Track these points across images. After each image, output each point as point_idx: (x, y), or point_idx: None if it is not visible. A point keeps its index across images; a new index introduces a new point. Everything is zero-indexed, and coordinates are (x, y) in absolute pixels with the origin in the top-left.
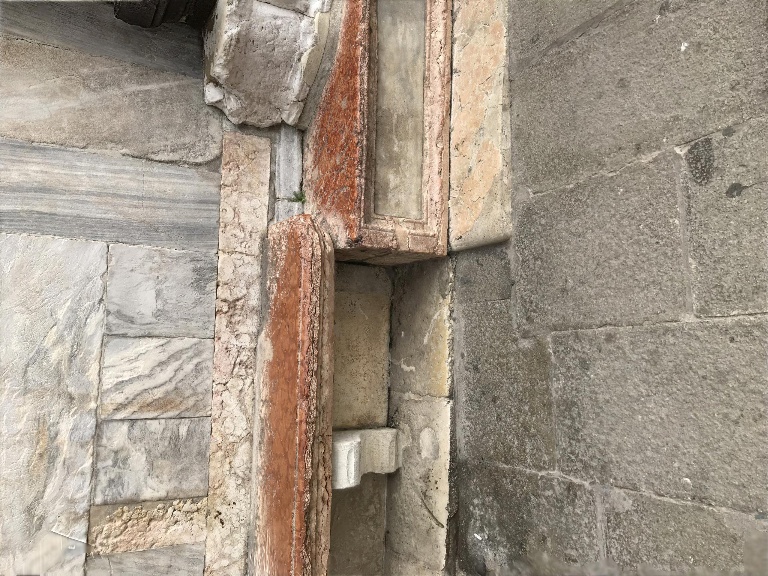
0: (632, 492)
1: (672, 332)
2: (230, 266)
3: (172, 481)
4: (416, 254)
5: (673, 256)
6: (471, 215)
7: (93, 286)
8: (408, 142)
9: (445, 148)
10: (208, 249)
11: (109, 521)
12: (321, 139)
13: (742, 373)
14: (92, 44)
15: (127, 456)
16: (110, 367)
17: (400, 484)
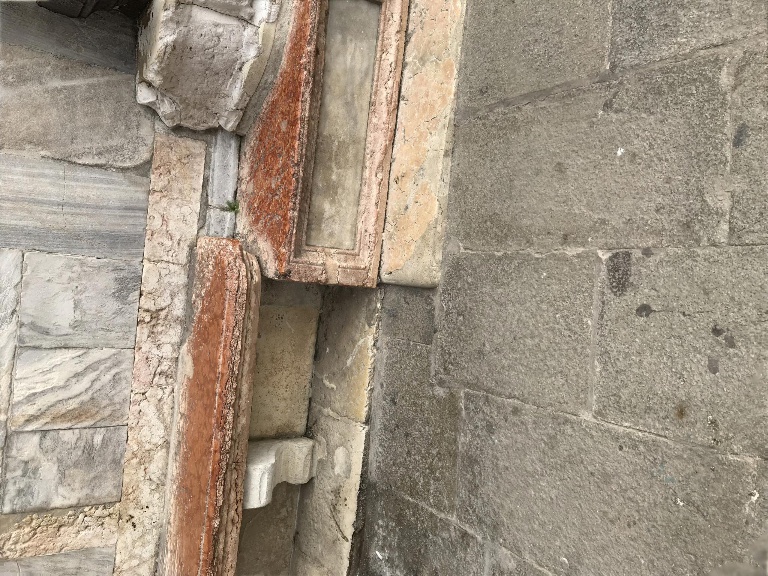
0: (517, 557)
1: (571, 424)
2: (155, 275)
3: (84, 489)
4: (345, 286)
5: (582, 354)
6: (403, 254)
7: (6, 296)
8: (347, 170)
9: (384, 179)
10: (132, 257)
11: (17, 528)
12: (258, 153)
13: (625, 481)
14: (10, 31)
15: (38, 466)
16: (22, 379)
17: (312, 492)
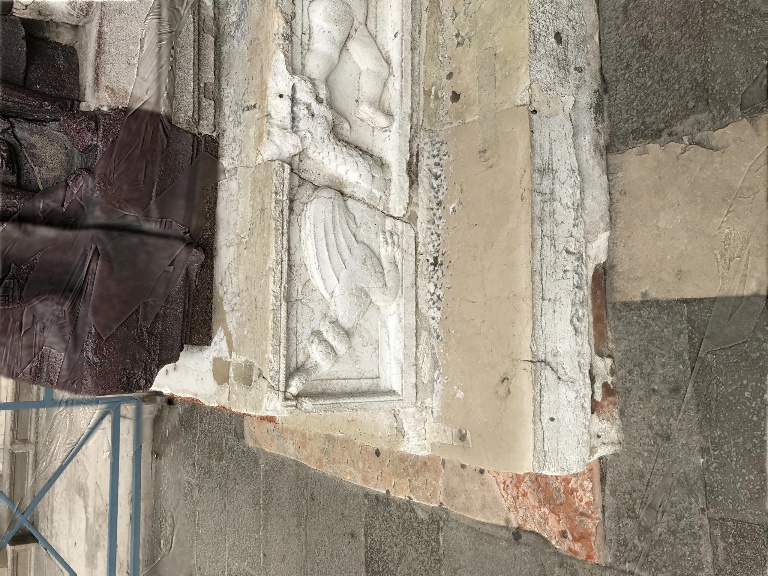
0: None
1: None
2: None
3: None
4: None
5: None
6: None
7: None
8: None
9: None
10: None
11: None
12: None
13: (217, 571)
14: None
15: None
16: None
17: None
